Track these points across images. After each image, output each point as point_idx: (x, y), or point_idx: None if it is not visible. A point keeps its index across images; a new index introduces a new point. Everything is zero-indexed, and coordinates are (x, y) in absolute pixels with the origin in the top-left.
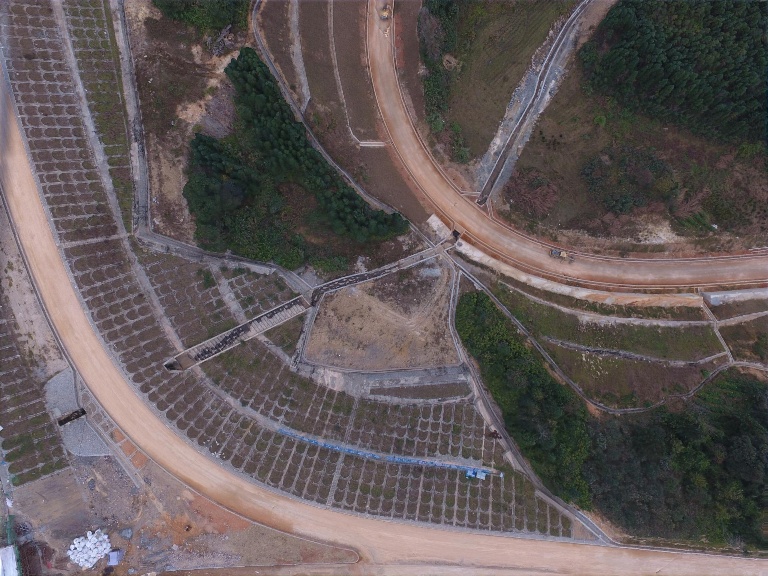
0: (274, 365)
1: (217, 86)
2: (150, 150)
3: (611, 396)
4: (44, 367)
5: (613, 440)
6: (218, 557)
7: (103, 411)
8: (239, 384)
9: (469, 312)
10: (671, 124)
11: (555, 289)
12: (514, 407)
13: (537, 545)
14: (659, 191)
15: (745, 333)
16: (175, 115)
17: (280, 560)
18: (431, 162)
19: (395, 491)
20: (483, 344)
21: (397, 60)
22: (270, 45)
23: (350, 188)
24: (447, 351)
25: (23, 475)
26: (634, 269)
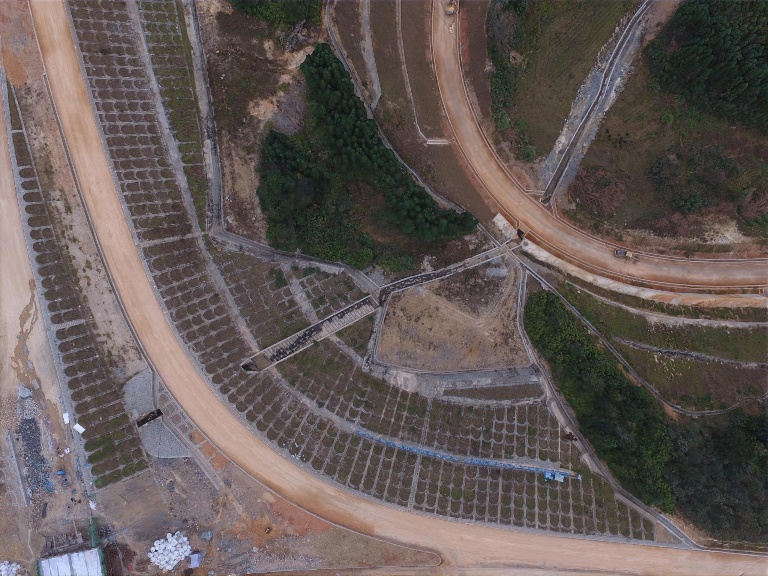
0: (347, 366)
1: (289, 82)
2: (223, 147)
3: (689, 398)
4: (123, 368)
5: (694, 443)
6: (299, 560)
7: (183, 412)
8: (314, 385)
9: (539, 313)
10: (739, 123)
11: (621, 289)
12: (590, 409)
13: (620, 548)
14: (728, 191)
15: None
16: (247, 112)
17: (362, 563)
18: (495, 160)
19: (475, 493)
20: (555, 345)
21: (462, 56)
22: (343, 41)
23: (421, 187)
24: (517, 352)
25: (105, 477)
26: (698, 269)
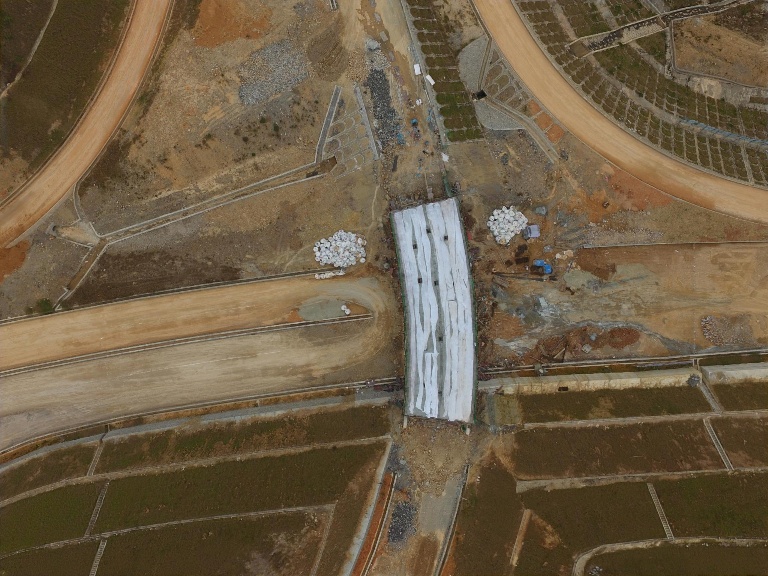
0: (651, 70)
1: None
2: None
3: None
4: (460, 33)
5: None
6: (640, 232)
7: (519, 81)
8: (629, 78)
9: None
10: None
11: None
12: None
13: None
14: None
15: None
16: None
17: (704, 237)
18: None
19: None
20: None
21: None
22: None
23: None
24: None
25: (454, 133)
26: None
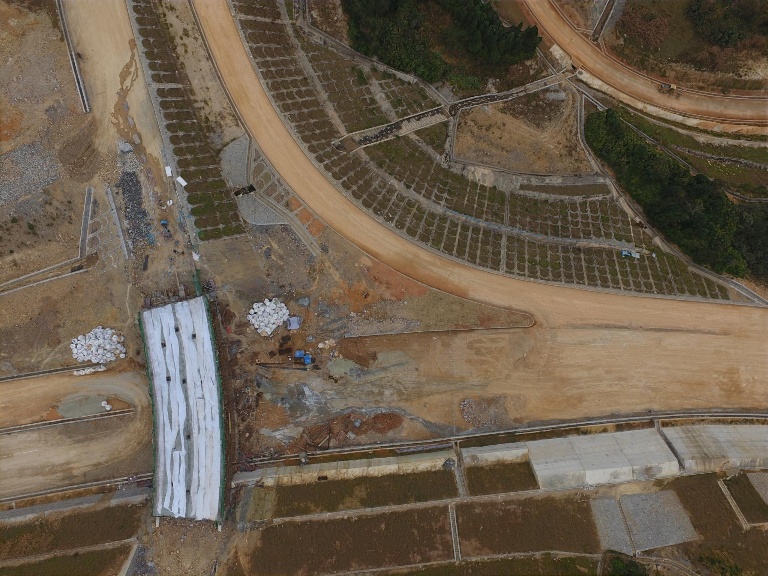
0: (427, 160)
1: None
2: None
3: (747, 185)
4: (220, 133)
5: (757, 217)
6: (398, 322)
7: (280, 178)
8: (400, 170)
9: (601, 124)
10: None
11: (669, 117)
12: (657, 198)
13: (700, 307)
14: (759, 27)
15: None
16: None
17: (458, 324)
18: None
19: (560, 264)
20: (619, 149)
21: None
22: None
23: (489, 2)
24: (581, 161)
25: (207, 231)
26: (734, 105)
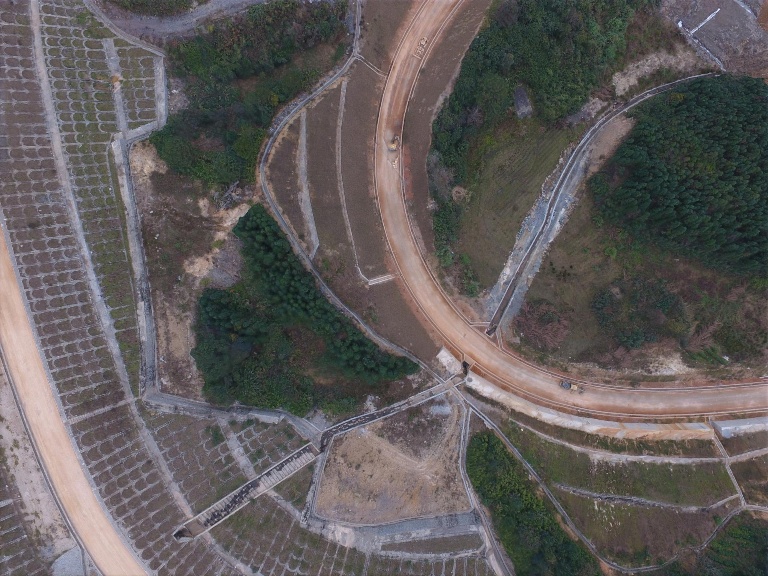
0: (284, 522)
1: (224, 239)
2: (157, 308)
3: (624, 556)
4: (51, 547)
5: None
6: None
7: None
8: (249, 548)
9: (480, 458)
10: (682, 256)
11: (566, 424)
12: (527, 565)
13: None
14: None
15: (757, 471)
16: (182, 269)
17: None
18: (440, 293)
19: None
20: (495, 494)
21: (406, 191)
22: (278, 197)
23: (360, 336)
24: (458, 497)
25: None
26: (645, 398)
